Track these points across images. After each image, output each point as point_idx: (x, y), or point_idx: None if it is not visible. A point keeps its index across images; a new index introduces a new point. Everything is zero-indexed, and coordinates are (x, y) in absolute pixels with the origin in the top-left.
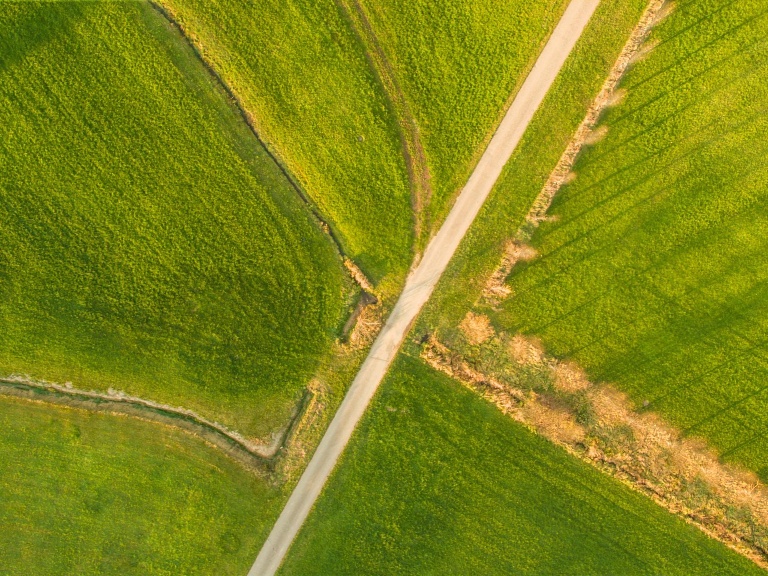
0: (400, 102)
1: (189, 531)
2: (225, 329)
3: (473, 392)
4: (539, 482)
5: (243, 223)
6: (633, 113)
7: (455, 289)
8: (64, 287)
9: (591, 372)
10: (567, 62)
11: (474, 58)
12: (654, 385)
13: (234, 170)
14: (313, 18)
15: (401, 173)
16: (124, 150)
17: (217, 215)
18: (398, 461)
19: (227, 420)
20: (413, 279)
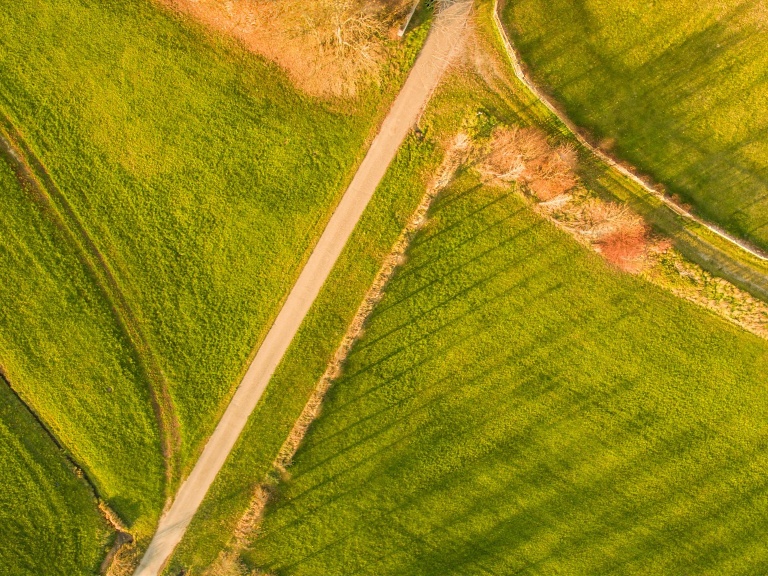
0: (147, 354)
1: None
2: None
3: None
4: None
5: None
6: (372, 367)
7: (207, 530)
8: None
9: None
10: (305, 321)
11: (217, 314)
12: None
13: None
14: (59, 275)
15: (150, 422)
16: None
17: None
18: None
19: None
20: (165, 521)
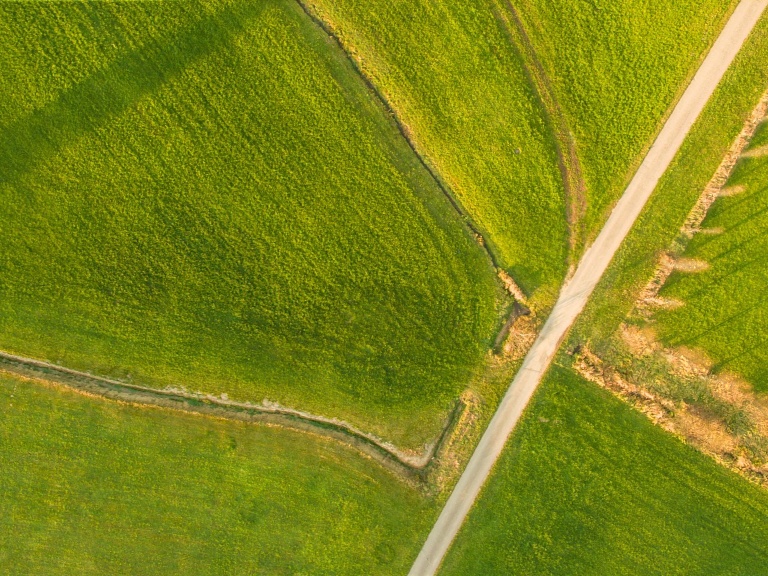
0: (557, 115)
1: (344, 542)
2: (379, 340)
3: (624, 403)
4: (688, 492)
5: (399, 235)
6: None
7: (608, 300)
8: (220, 299)
9: (740, 382)
10: (726, 75)
11: (632, 71)
12: None
13: (391, 182)
14: (472, 31)
15: (557, 185)
16: (281, 162)
17: (373, 227)
18: (550, 471)
19: (381, 431)
20: (567, 290)
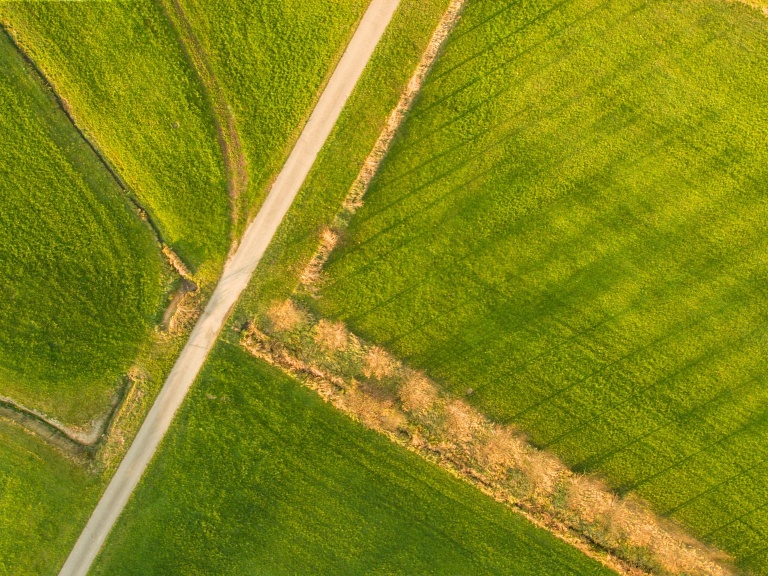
0: (214, 88)
1: (7, 518)
2: (43, 316)
3: (294, 380)
4: (362, 470)
5: (60, 210)
6: (447, 99)
7: (273, 276)
8: None
9: (413, 360)
10: (378, 48)
11: (286, 44)
12: (477, 373)
13: (50, 157)
14: (125, 4)
15: (217, 160)
16: None
17: (34, 202)
18: (218, 449)
19: (46, 407)
20: (231, 266)
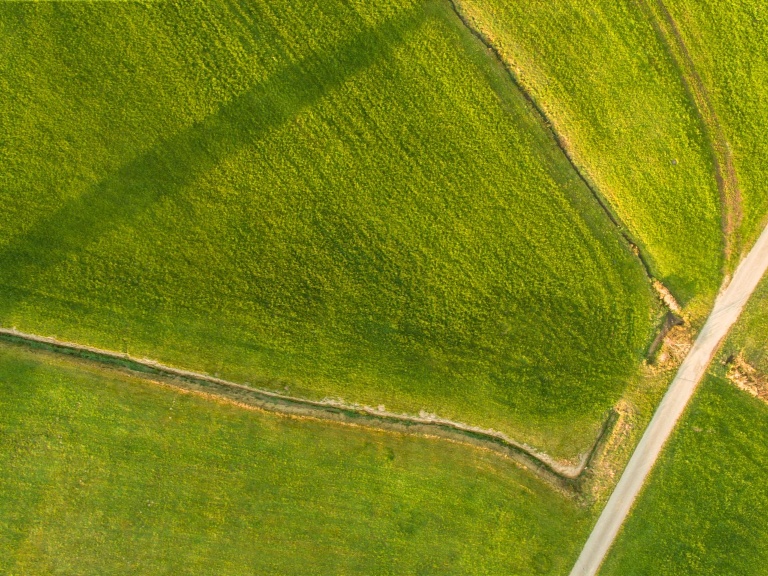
0: (714, 125)
1: (501, 552)
2: (535, 351)
3: None
4: None
5: (555, 246)
6: None
7: (763, 310)
8: (377, 311)
9: None
10: None
11: None
12: None
13: (548, 193)
14: (631, 43)
15: (713, 196)
16: (439, 174)
17: (530, 238)
18: (703, 481)
19: (536, 441)
20: (722, 300)
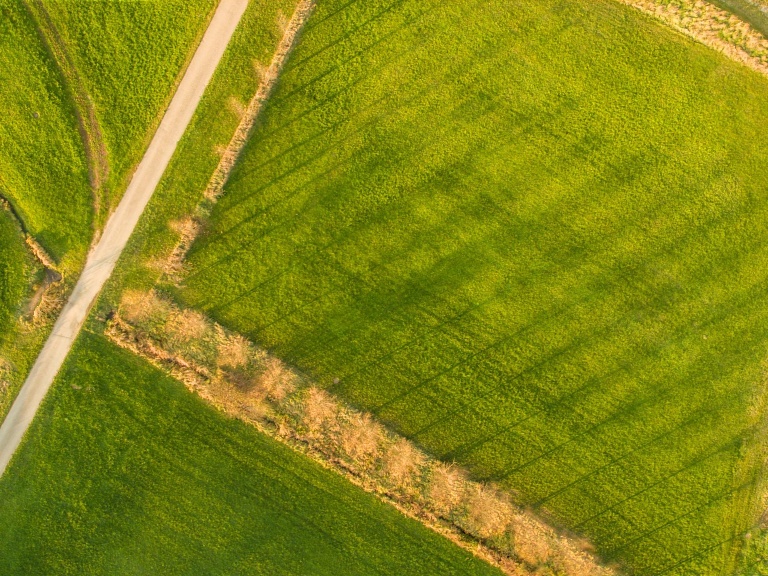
0: (74, 78)
1: None
2: None
3: (160, 370)
4: (230, 460)
5: None
6: (305, 87)
7: (136, 266)
8: None
9: (279, 349)
10: (234, 36)
11: (144, 33)
12: (343, 362)
13: None
14: None
15: (78, 149)
16: None
17: None
18: (84, 439)
19: None
20: (94, 256)
